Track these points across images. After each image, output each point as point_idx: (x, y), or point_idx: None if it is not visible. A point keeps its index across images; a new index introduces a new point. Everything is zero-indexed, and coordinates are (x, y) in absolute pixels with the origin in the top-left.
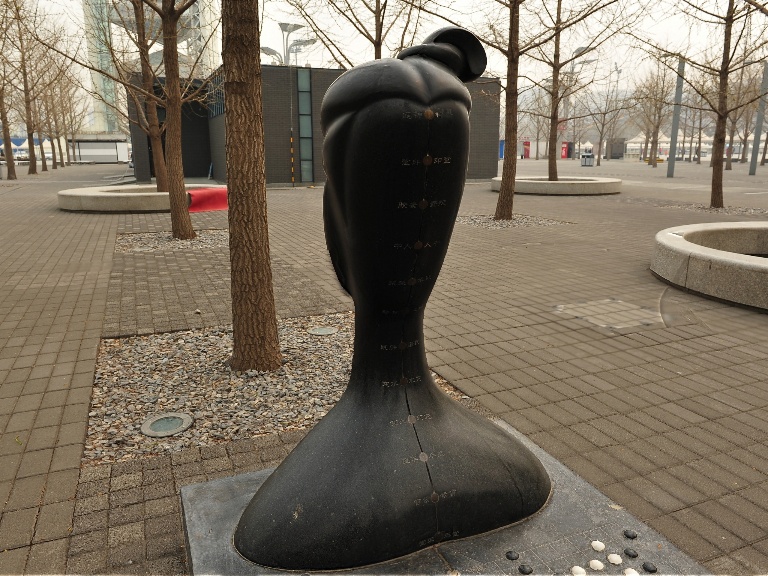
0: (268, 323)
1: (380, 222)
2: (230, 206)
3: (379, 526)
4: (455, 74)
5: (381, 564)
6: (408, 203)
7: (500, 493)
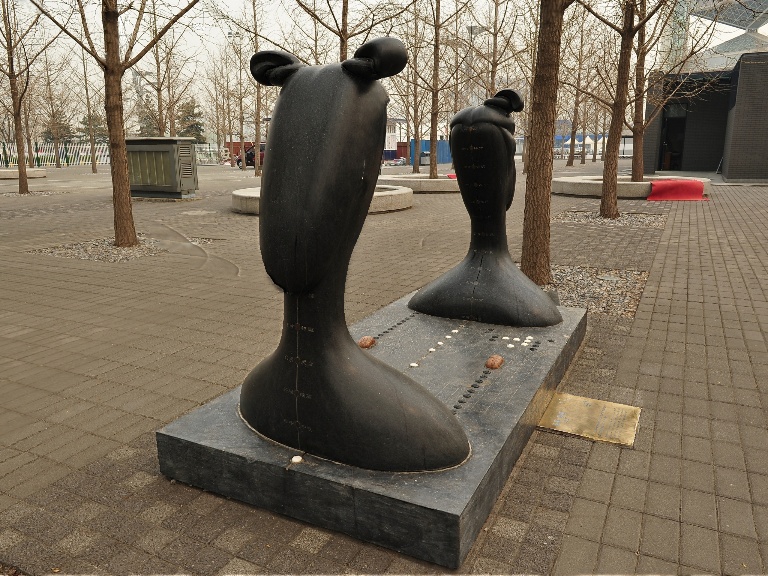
0: (540, 254)
1: (460, 174)
2: (527, 179)
3: (445, 302)
4: (504, 109)
5: (444, 318)
6: (467, 166)
7: (506, 309)
